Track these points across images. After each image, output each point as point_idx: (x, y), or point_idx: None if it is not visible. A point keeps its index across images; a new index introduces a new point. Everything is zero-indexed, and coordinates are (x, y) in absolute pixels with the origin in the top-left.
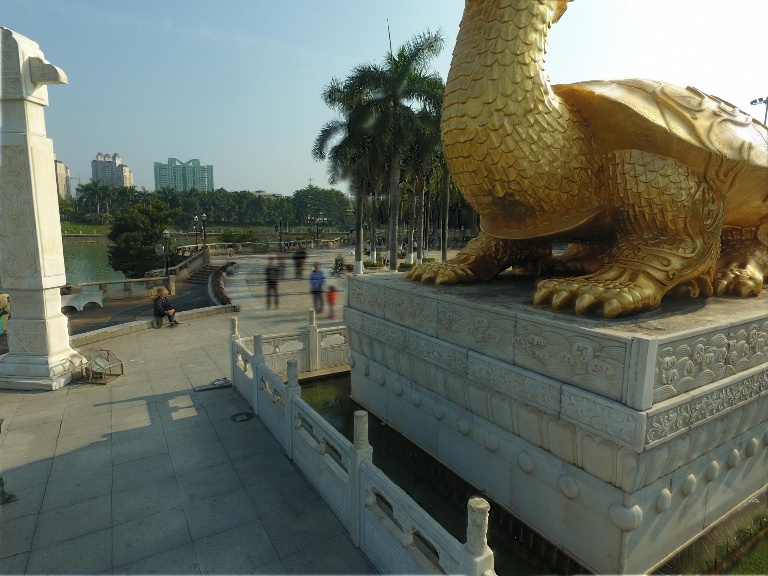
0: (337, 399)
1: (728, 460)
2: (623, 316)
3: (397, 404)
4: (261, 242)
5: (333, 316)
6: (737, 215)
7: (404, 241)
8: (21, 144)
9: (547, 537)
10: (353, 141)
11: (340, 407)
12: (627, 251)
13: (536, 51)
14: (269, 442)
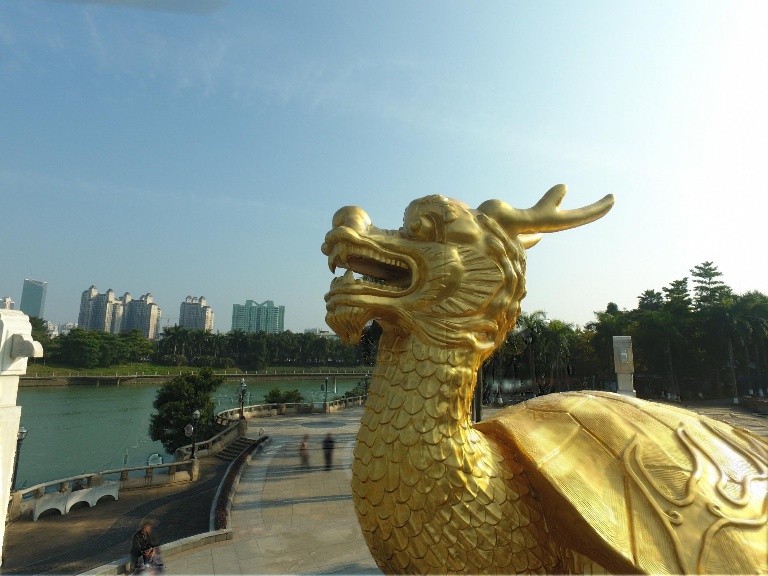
0: None
1: None
2: None
3: None
4: (307, 400)
5: (330, 558)
6: None
7: None
8: None
9: None
10: (377, 331)
11: None
12: None
13: (449, 423)
14: None
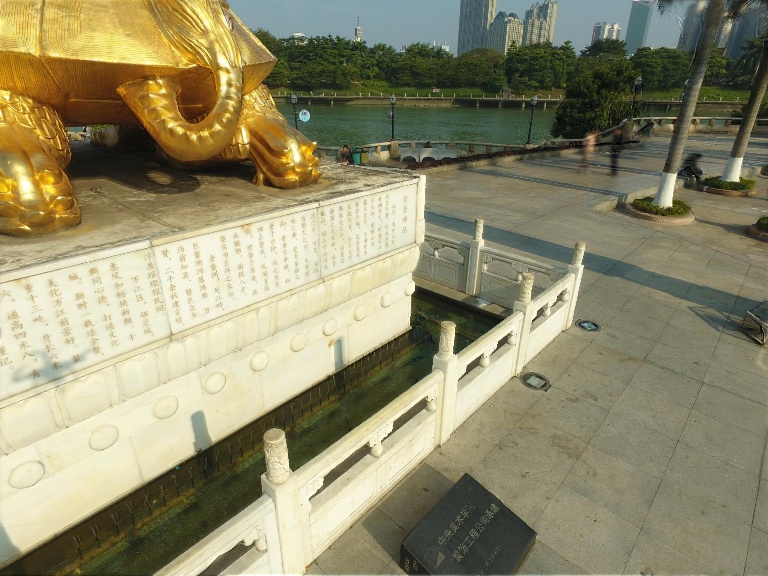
0: None
1: None
2: None
3: None
4: None
5: None
6: None
7: None
8: None
9: None
10: None
11: None
12: None
13: None
14: None
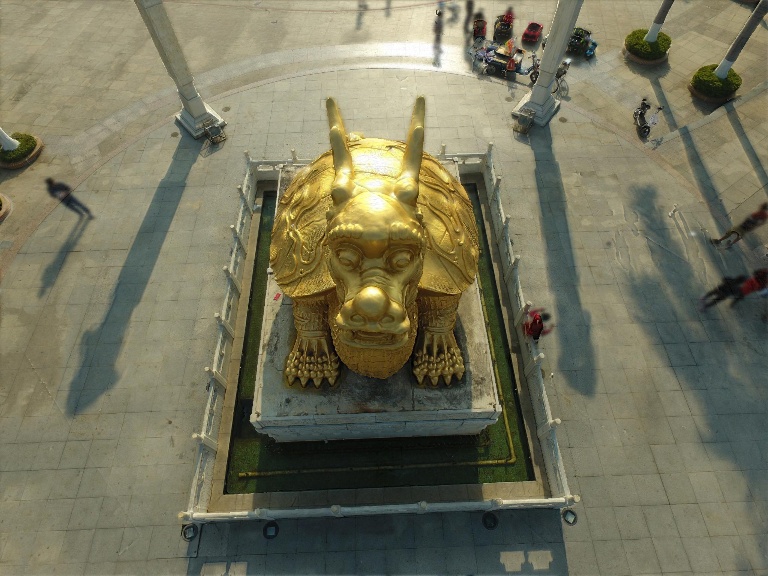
0: (273, 451)
1: None
2: None
3: (337, 435)
4: None
5: (57, 352)
6: None
7: None
8: None
9: (449, 435)
10: None
11: (280, 453)
12: (435, 322)
13: None
14: (316, 523)
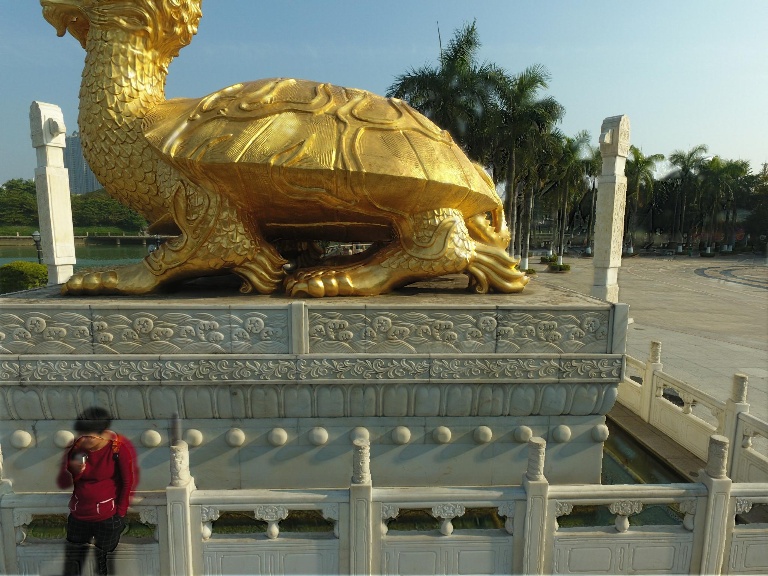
0: None
1: (141, 437)
2: (73, 295)
3: None
4: None
5: None
6: (299, 211)
7: (536, 245)
8: (44, 173)
9: None
10: None
11: None
12: None
13: (105, 80)
14: None
